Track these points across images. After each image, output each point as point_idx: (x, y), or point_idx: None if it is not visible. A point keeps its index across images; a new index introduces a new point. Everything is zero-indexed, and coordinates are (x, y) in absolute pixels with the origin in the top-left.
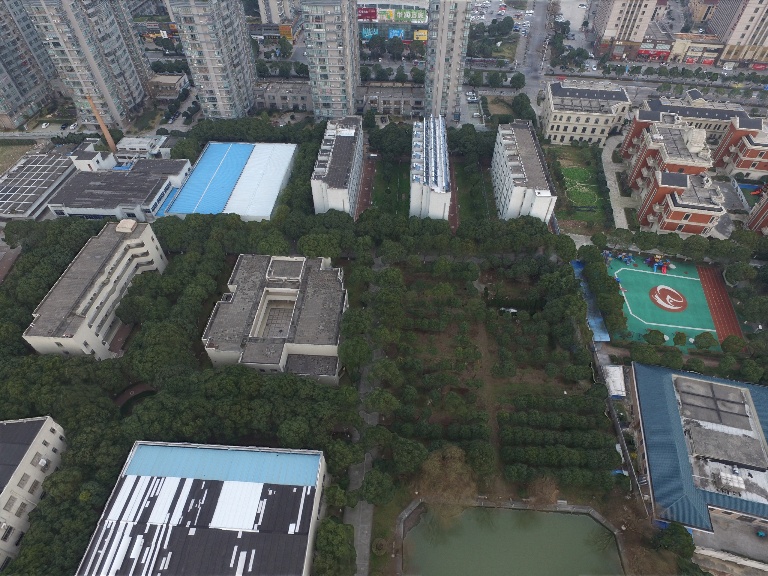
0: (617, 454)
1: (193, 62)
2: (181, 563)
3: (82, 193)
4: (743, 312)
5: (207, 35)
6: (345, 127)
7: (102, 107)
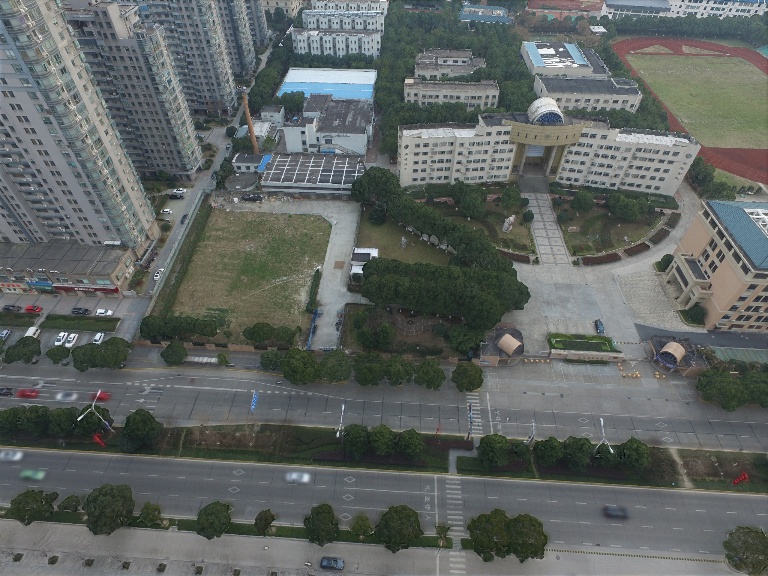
0: (498, 21)
1: (216, 49)
2: (567, 56)
3: (350, 125)
4: (431, 3)
5: (216, 17)
6: (307, 32)
7: (196, 140)
